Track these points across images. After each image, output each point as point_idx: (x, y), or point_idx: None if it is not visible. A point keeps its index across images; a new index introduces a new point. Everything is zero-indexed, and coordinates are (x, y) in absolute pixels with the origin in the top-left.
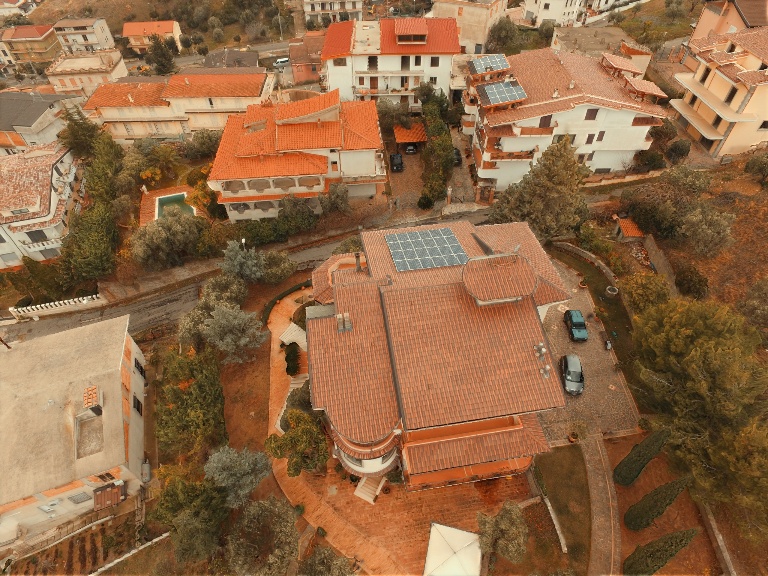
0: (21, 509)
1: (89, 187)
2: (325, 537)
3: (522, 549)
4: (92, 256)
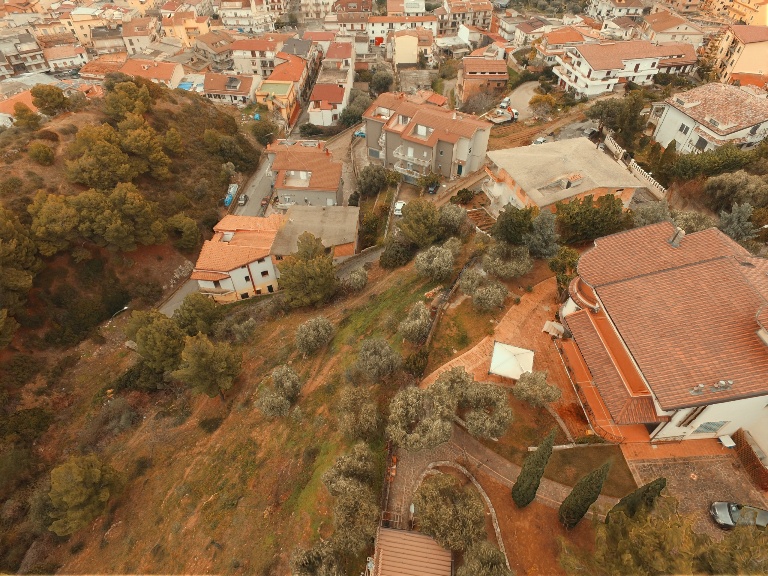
0: (508, 188)
1: (767, 140)
2: (515, 305)
3: (524, 393)
4: (692, 161)
